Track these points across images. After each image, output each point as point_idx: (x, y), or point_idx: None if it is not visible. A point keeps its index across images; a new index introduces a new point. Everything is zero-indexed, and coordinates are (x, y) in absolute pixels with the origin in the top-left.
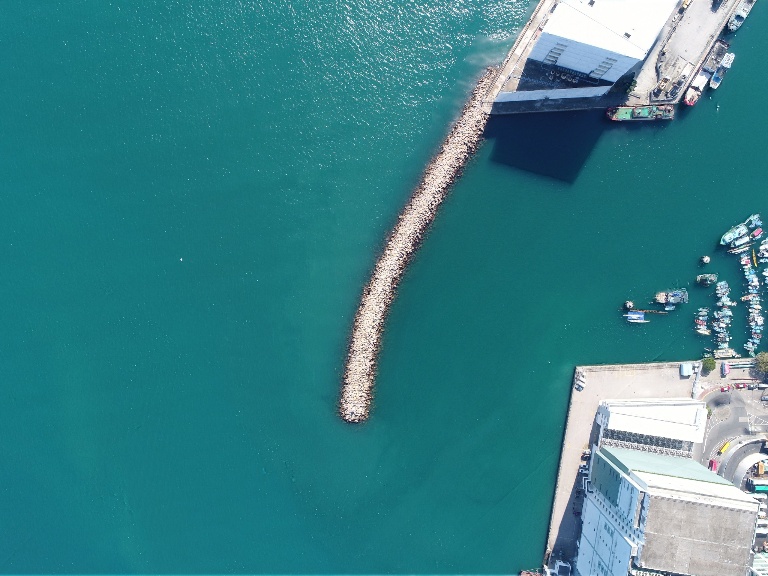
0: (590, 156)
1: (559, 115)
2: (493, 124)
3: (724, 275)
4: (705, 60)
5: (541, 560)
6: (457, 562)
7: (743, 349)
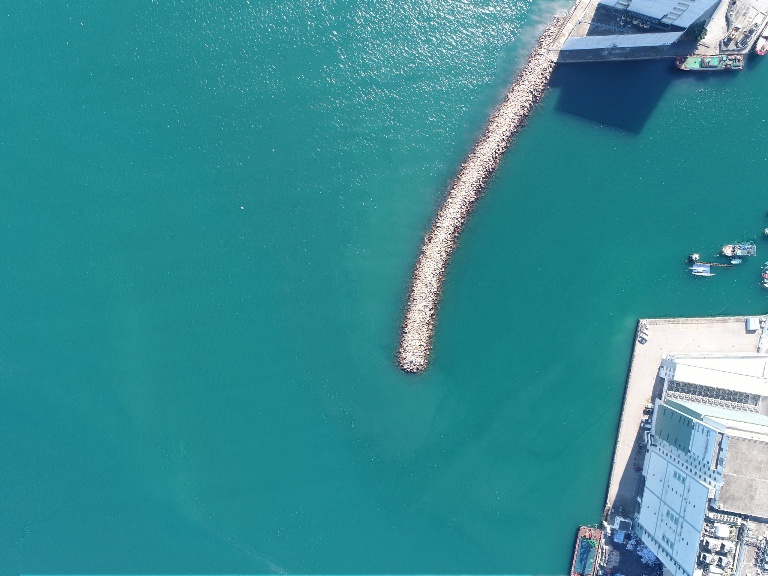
0: (657, 106)
1: (626, 64)
2: (559, 73)
3: None
4: None
5: (600, 516)
6: (514, 516)
7: None
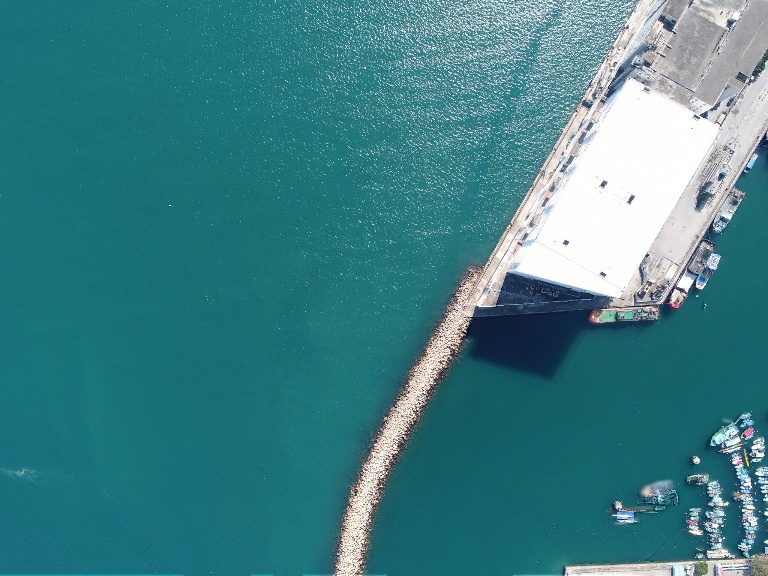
0: (575, 356)
1: (542, 317)
2: (476, 325)
3: (715, 475)
4: (690, 260)
5: None
6: None
7: (737, 549)
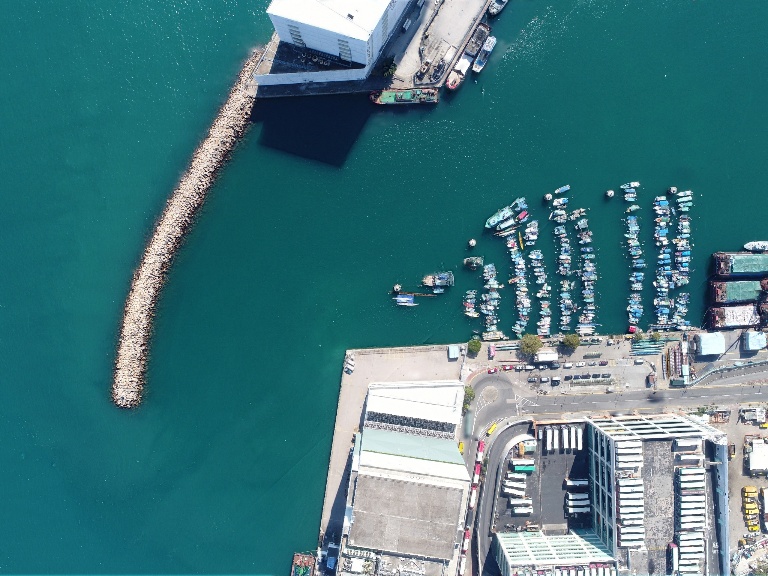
0: (358, 140)
1: (325, 98)
2: (261, 108)
3: (491, 258)
4: None
5: (316, 542)
6: (233, 546)
7: (511, 331)
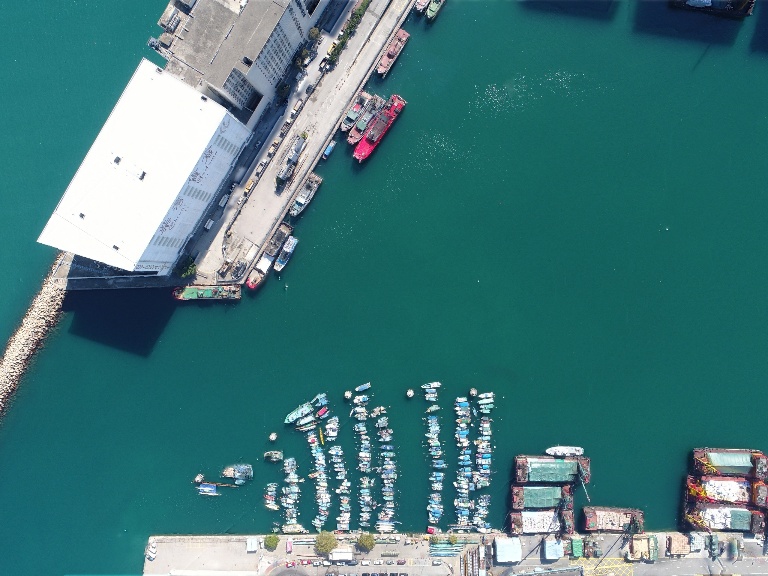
0: (164, 331)
1: (132, 292)
2: (73, 298)
3: (292, 452)
4: None
5: None
6: None
7: (311, 525)
